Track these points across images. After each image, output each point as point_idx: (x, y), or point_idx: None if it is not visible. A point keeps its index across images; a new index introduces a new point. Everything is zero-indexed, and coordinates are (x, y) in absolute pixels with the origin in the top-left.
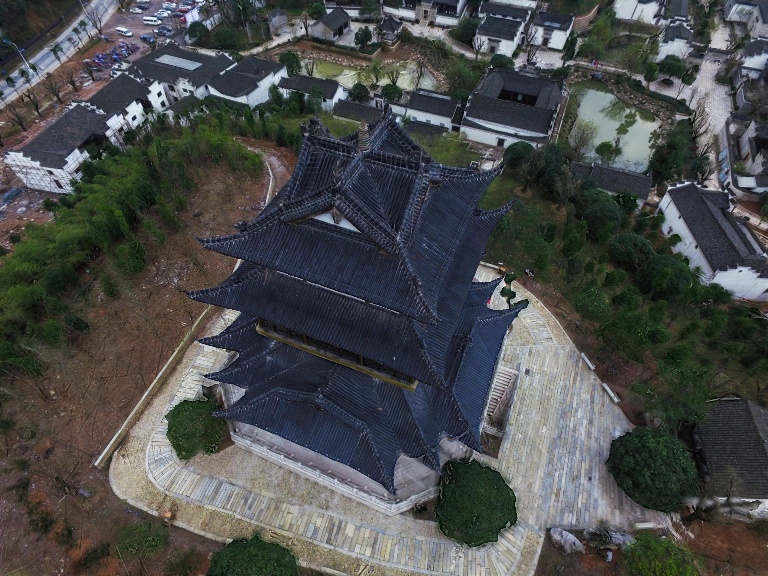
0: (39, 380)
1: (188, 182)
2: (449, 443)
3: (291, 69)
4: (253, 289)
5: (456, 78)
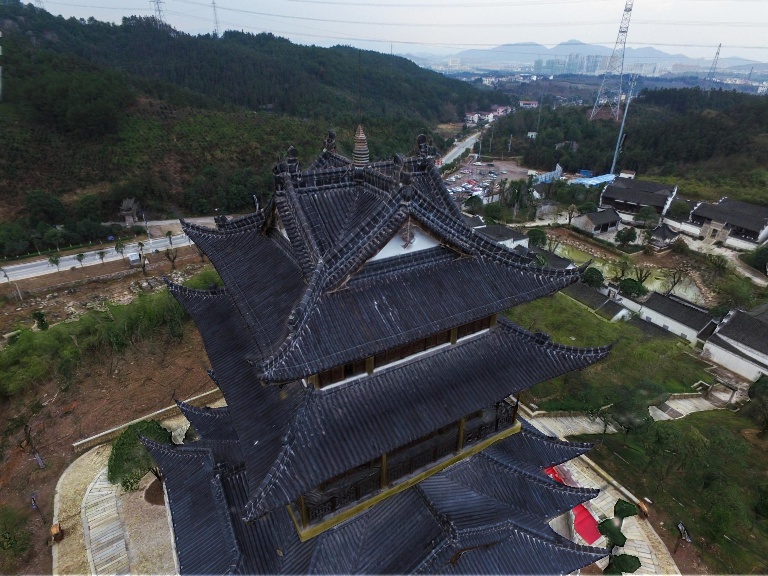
0: (117, 356)
1: None
2: None
3: (535, 243)
4: (221, 306)
5: (730, 299)
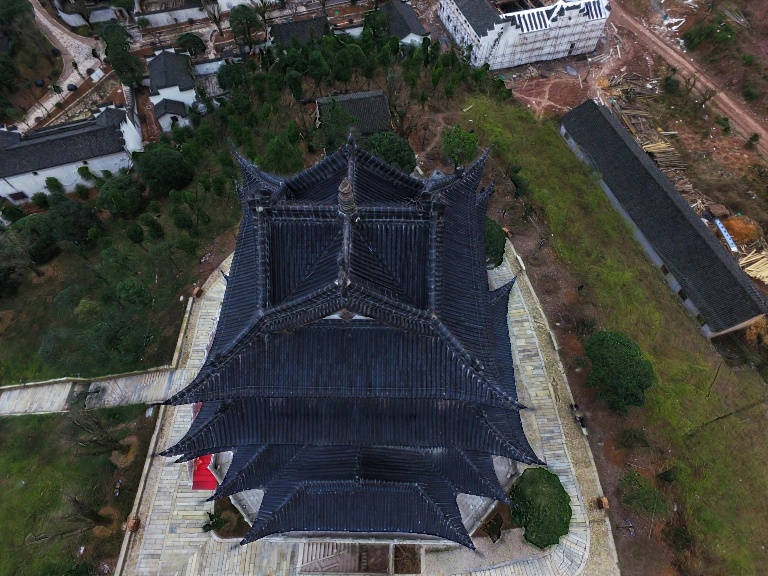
0: None
1: None
2: None
3: None
4: None
5: None
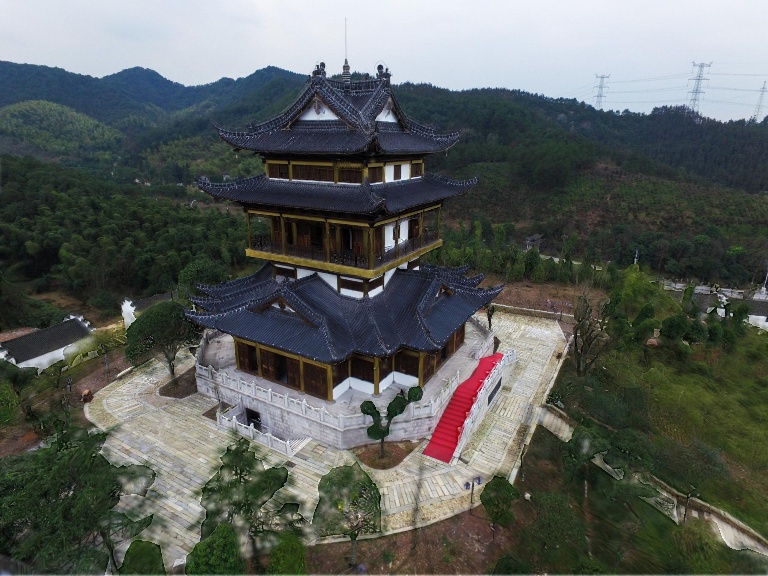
0: None
1: (561, 274)
2: (234, 368)
3: None
4: None
5: None
